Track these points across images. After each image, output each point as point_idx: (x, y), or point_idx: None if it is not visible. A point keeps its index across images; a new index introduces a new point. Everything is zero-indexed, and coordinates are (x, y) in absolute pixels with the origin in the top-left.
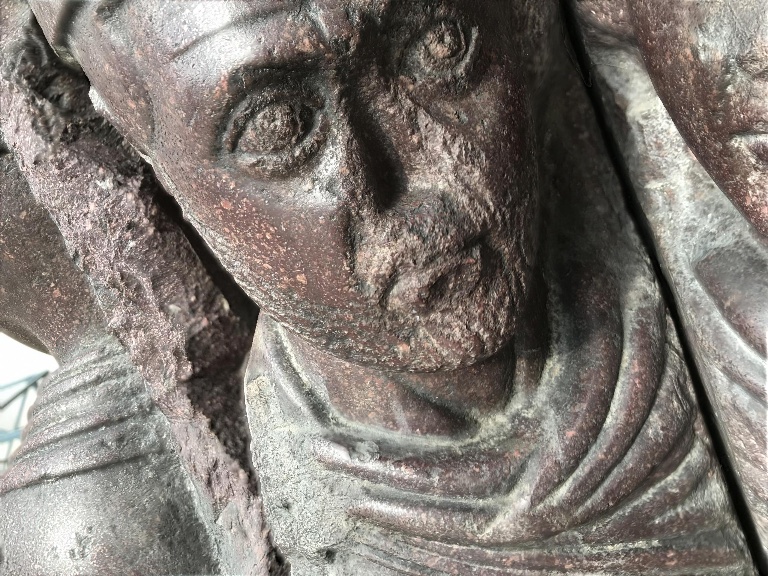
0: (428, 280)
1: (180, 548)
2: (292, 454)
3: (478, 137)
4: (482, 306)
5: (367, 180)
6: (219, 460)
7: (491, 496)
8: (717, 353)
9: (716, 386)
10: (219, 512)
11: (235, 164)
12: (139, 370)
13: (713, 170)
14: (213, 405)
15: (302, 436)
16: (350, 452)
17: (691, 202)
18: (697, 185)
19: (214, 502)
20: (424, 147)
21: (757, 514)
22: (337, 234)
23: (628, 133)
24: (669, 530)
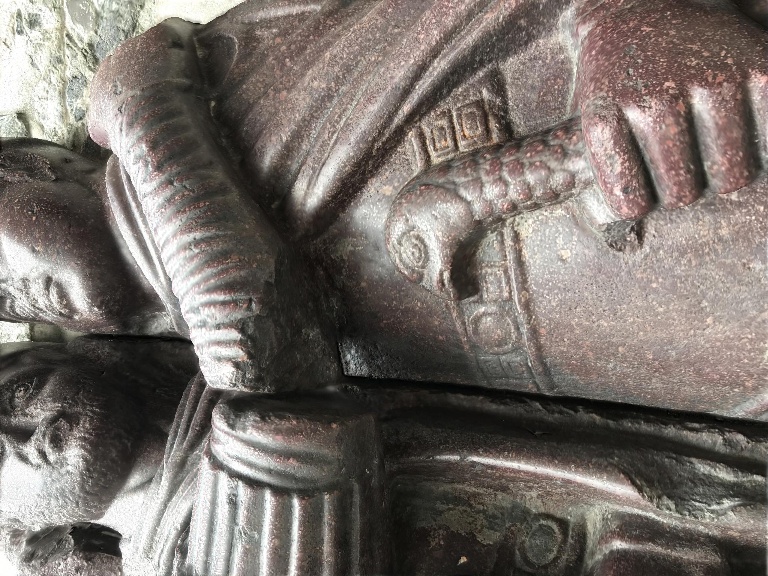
0: None
1: None
2: (135, 569)
3: None
4: None
5: None
6: None
7: None
8: None
9: None
10: None
11: None
12: None
13: None
14: None
15: None
16: None
17: None
18: None
19: None
20: None
21: None
22: (20, 461)
23: None
24: None
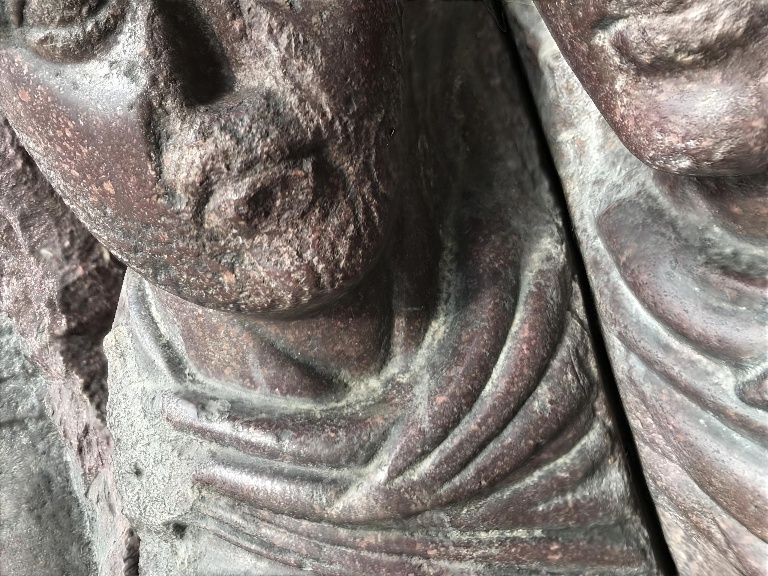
0: (245, 191)
1: (47, 522)
2: (143, 412)
3: (313, 30)
4: (317, 231)
5: (172, 66)
6: (89, 425)
7: (346, 465)
8: (613, 317)
9: (614, 357)
10: (89, 484)
11: (24, 42)
12: (13, 323)
13: (587, 84)
14: (89, 365)
15: (154, 392)
16: (198, 410)
17: (601, 154)
18: (608, 135)
19: (83, 472)
20: (248, 37)
21: (660, 508)
22: (137, 129)
23: (541, 81)
24: (555, 519)
